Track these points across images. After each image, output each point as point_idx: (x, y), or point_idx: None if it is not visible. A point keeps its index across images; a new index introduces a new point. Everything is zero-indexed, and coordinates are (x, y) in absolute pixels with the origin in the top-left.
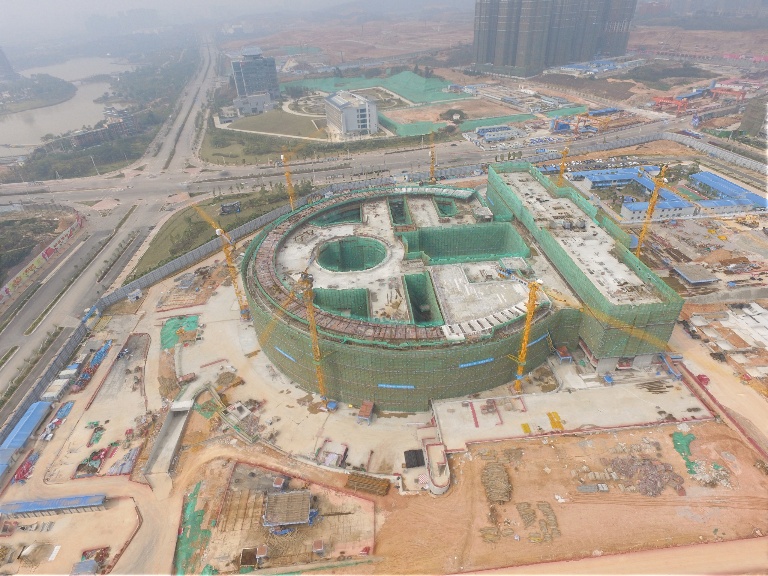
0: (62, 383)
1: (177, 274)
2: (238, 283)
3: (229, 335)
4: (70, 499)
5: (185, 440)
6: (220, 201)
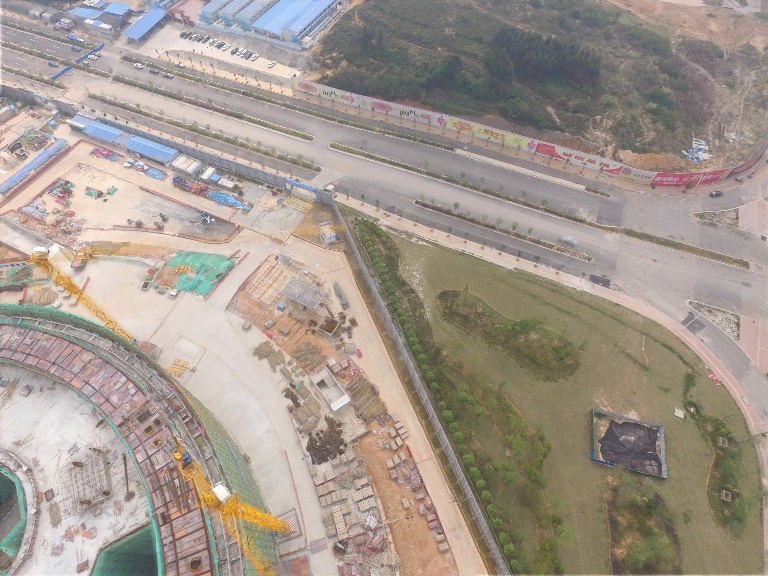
0: (190, 168)
1: (360, 290)
2: (252, 367)
3: (122, 320)
4: (22, 173)
5: (3, 249)
6: (707, 435)
